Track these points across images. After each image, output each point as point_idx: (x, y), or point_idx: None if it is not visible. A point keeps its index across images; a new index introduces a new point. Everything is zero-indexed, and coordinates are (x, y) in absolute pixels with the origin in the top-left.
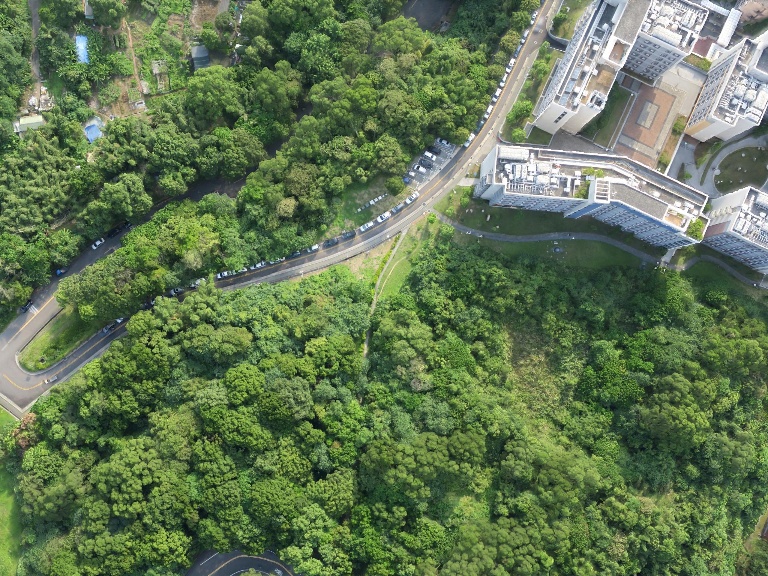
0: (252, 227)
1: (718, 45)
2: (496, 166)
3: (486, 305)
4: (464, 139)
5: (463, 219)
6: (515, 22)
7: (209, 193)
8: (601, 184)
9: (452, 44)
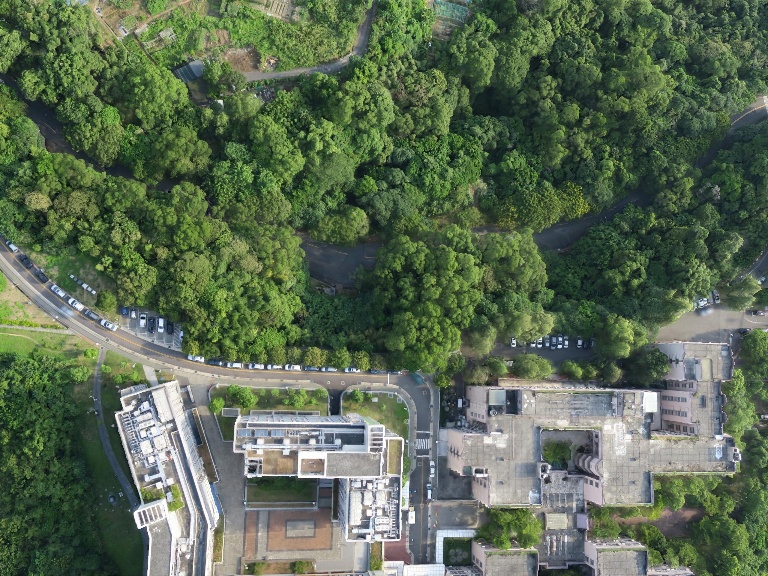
0: (9, 176)
1: (403, 568)
2: (143, 393)
3: (3, 449)
4: (188, 351)
5: (106, 386)
6: (335, 353)
7: (48, 125)
8: (156, 510)
9: (291, 301)
